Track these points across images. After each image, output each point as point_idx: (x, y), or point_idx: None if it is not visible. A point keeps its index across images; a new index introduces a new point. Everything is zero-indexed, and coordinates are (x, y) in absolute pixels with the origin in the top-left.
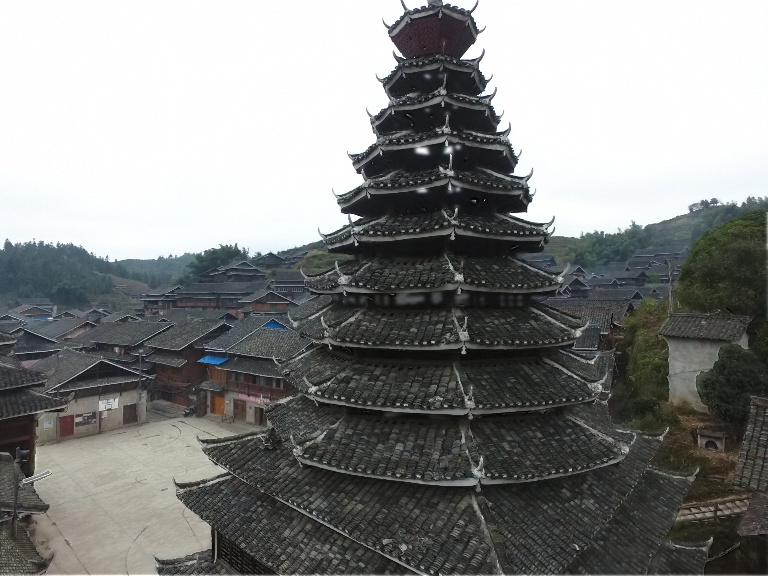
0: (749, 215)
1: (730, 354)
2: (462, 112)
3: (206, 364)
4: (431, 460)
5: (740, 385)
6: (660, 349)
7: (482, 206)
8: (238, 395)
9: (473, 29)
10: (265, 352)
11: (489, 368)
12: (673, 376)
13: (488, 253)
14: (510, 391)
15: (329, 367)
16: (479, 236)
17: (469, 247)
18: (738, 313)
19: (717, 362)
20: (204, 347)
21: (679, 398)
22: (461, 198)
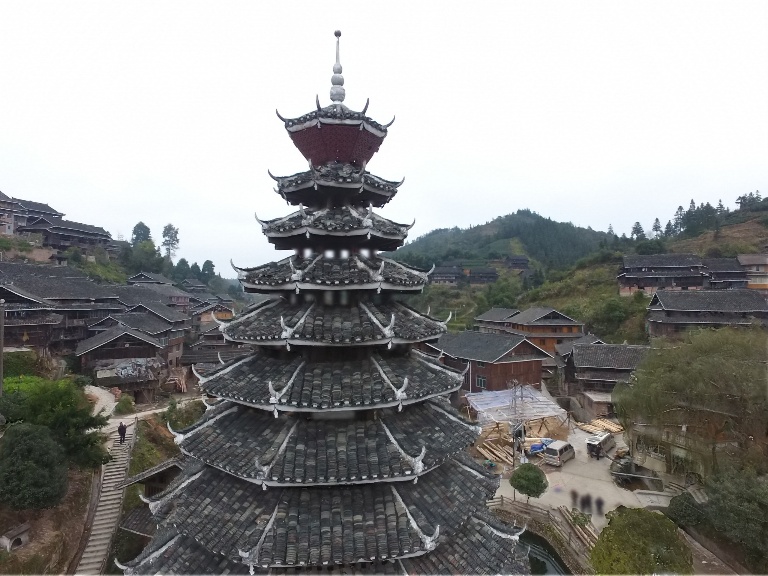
0: None
1: (32, 435)
2: None
3: None
4: None
5: (50, 462)
6: None
7: None
8: None
9: None
10: None
11: None
12: None
13: None
14: None
15: (465, 537)
16: None
17: None
18: None
19: (22, 448)
20: None
21: None
22: None
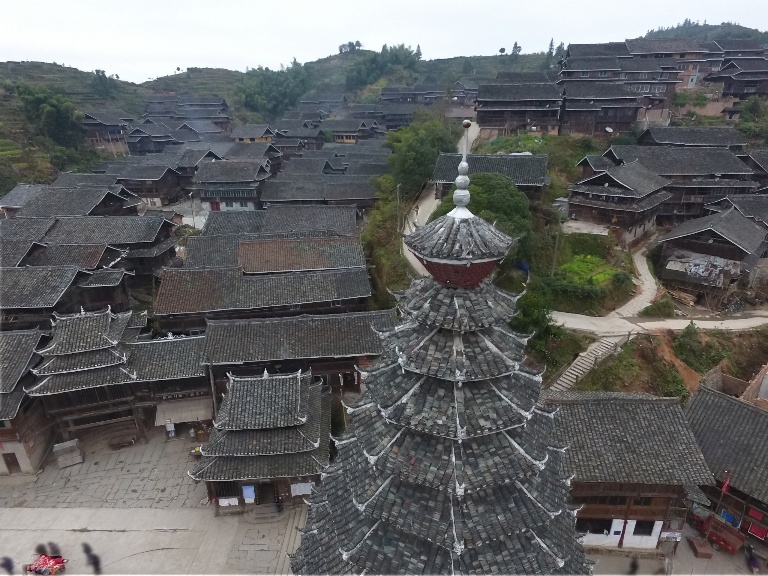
0: (477, 180)
1: None
2: None
3: None
4: None
5: None
6: (408, 280)
7: None
8: None
9: None
10: None
11: None
12: None
13: None
14: None
15: None
16: None
17: None
18: None
19: None
20: None
21: None
22: None
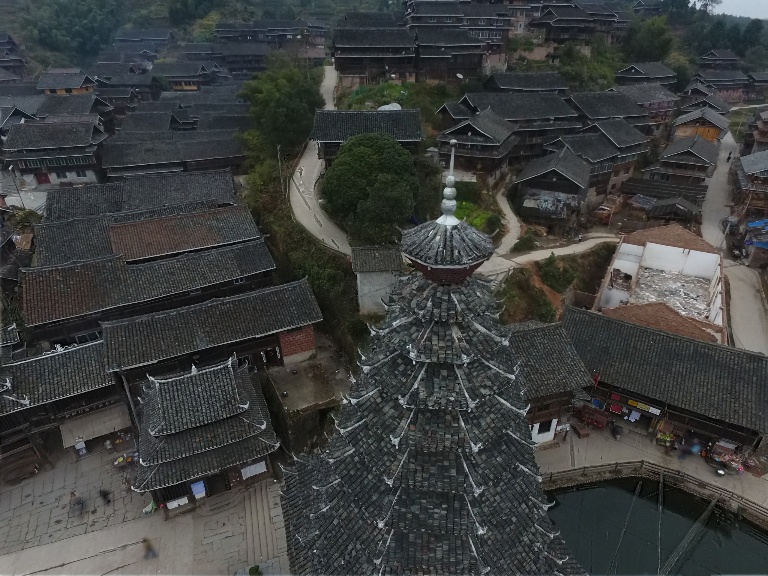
0: (366, 142)
1: None
2: None
3: None
4: (536, 572)
5: None
6: (307, 245)
7: None
8: None
9: None
10: None
11: None
12: (363, 296)
13: None
14: None
15: (447, 573)
16: None
17: None
18: (394, 244)
19: None
20: None
21: (367, 309)
22: None
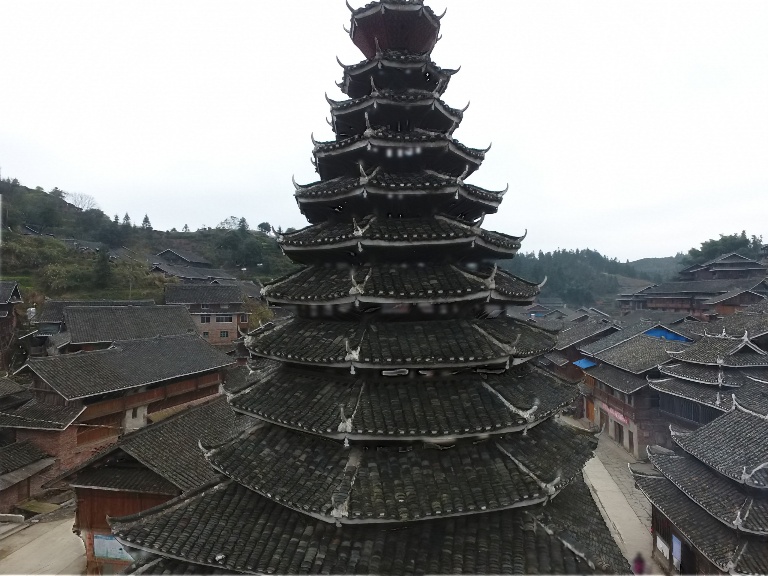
0: None
1: None
2: (360, 115)
3: (577, 367)
4: None
5: None
6: None
7: (349, 212)
8: (602, 404)
9: (404, 6)
10: (623, 362)
11: (300, 379)
12: None
13: (340, 262)
14: (277, 402)
15: None
16: (301, 249)
17: (317, 259)
18: None
19: None
20: (580, 349)
21: None
22: (328, 209)
